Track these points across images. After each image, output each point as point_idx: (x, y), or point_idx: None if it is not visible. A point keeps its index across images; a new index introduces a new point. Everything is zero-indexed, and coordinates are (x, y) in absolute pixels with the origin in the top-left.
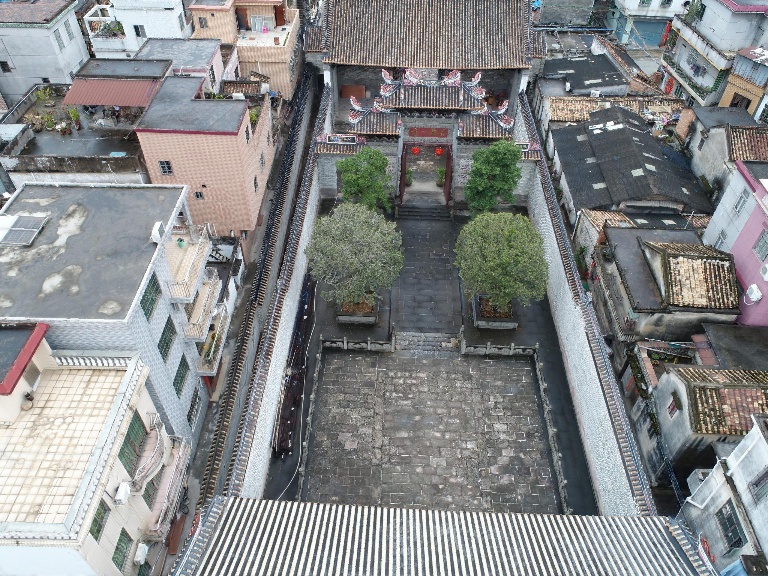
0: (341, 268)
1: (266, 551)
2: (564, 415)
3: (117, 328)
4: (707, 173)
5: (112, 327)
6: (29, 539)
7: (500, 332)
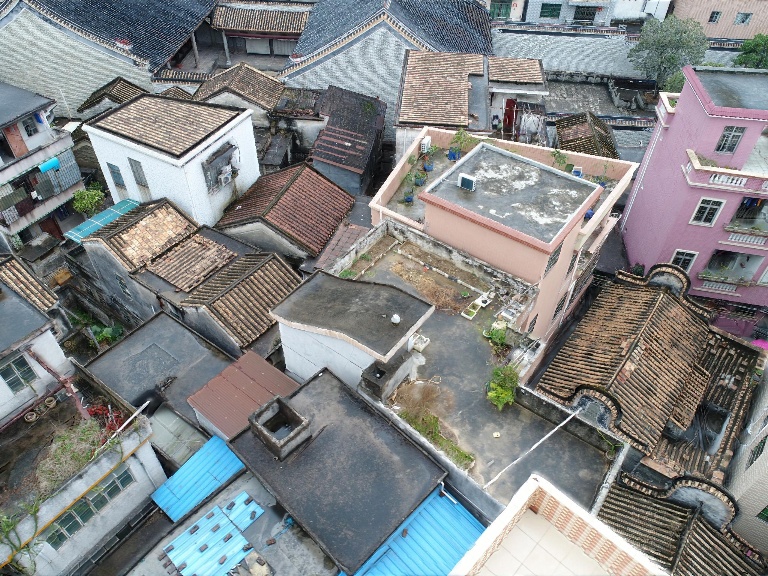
0: None
1: (465, 6)
2: None
3: None
4: None
5: None
6: None
7: None
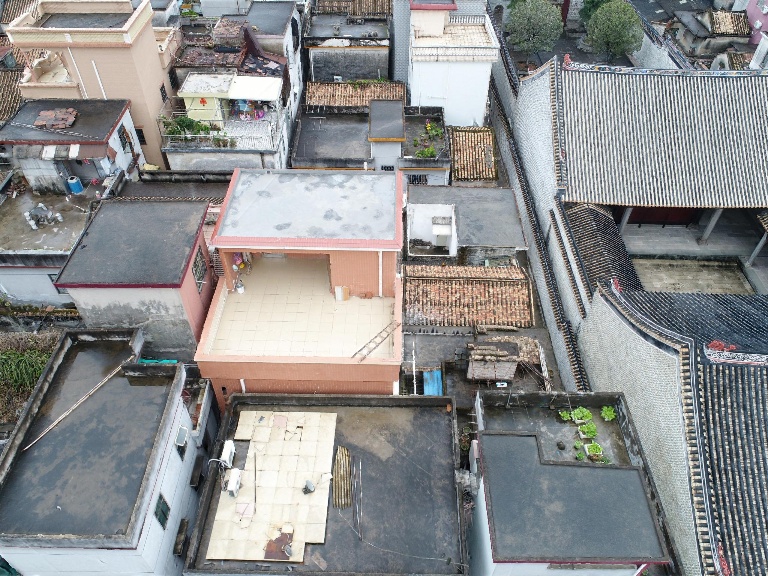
0: (532, 29)
1: None
2: None
3: (479, 2)
4: (725, 4)
5: (477, 1)
6: (479, 56)
7: None
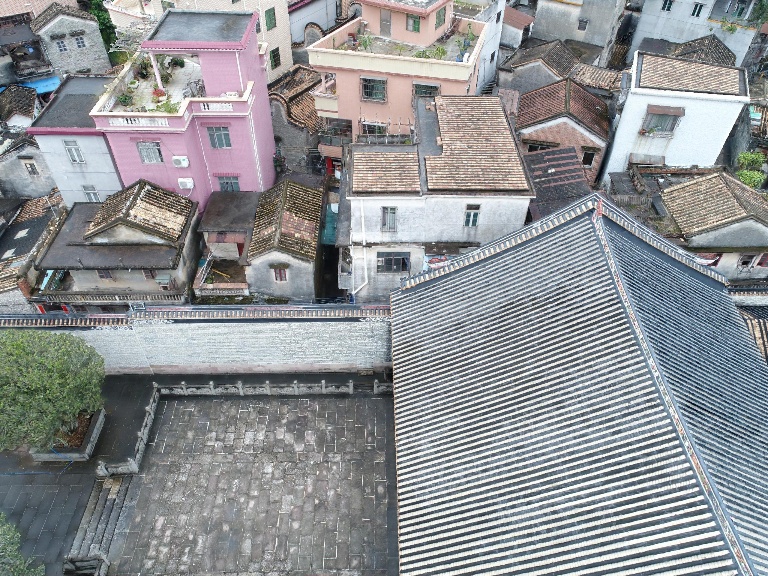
0: None
1: None
2: (235, 383)
3: None
4: None
5: None
6: None
7: (106, 432)
